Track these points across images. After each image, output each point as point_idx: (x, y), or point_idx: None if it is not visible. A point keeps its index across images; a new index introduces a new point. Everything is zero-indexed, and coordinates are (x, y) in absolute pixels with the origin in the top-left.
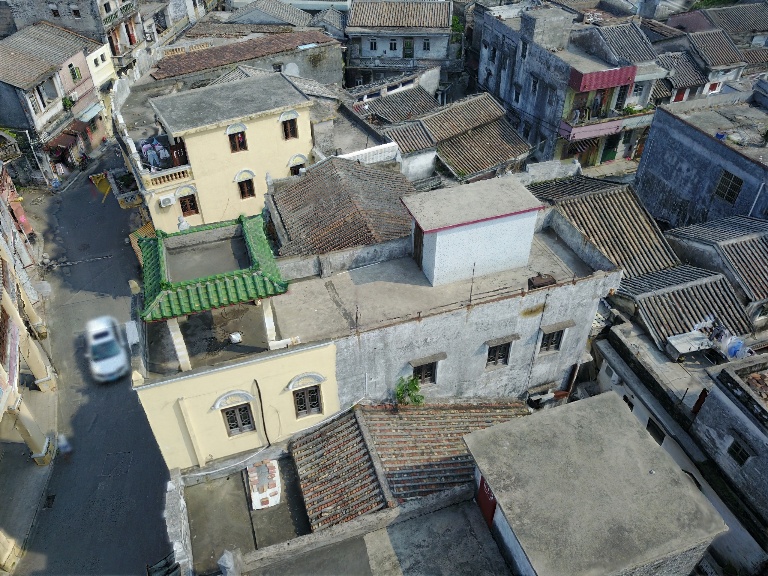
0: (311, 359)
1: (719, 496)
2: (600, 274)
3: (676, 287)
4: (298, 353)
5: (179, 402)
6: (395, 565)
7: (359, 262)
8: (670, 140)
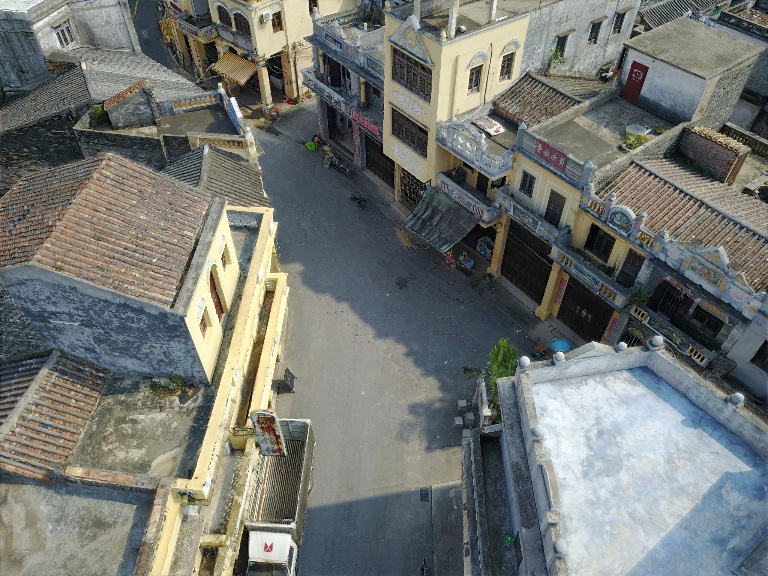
0: (517, 28)
1: None
2: None
3: (659, 3)
4: (514, 21)
5: (458, 57)
6: (598, 126)
7: None
8: None
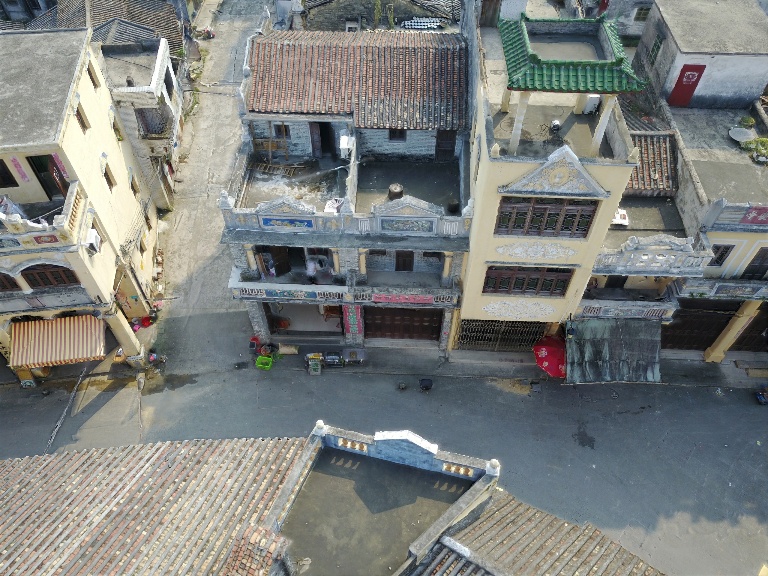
0: None
1: None
2: None
3: None
4: None
5: None
6: (705, 150)
7: None
8: None
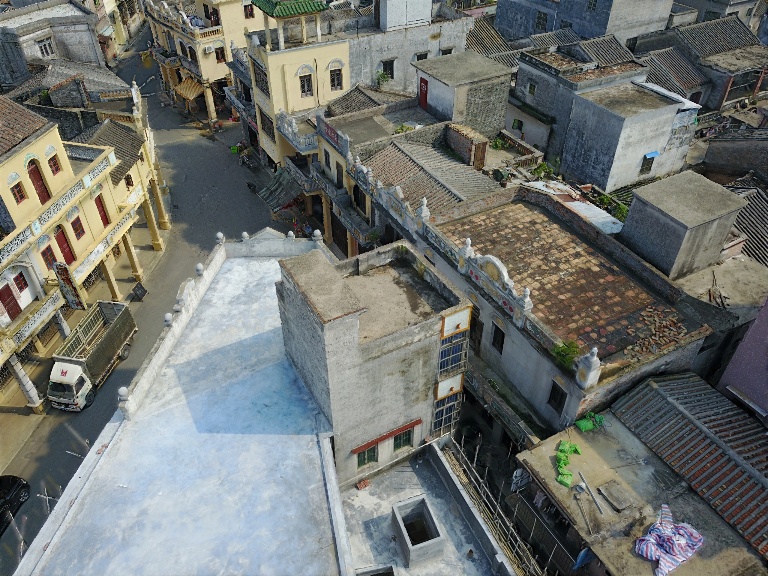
0: (338, 50)
1: (527, 113)
2: (464, 18)
3: (509, 52)
4: (333, 44)
5: (284, 65)
6: (388, 122)
7: (348, 28)
8: (509, 2)
